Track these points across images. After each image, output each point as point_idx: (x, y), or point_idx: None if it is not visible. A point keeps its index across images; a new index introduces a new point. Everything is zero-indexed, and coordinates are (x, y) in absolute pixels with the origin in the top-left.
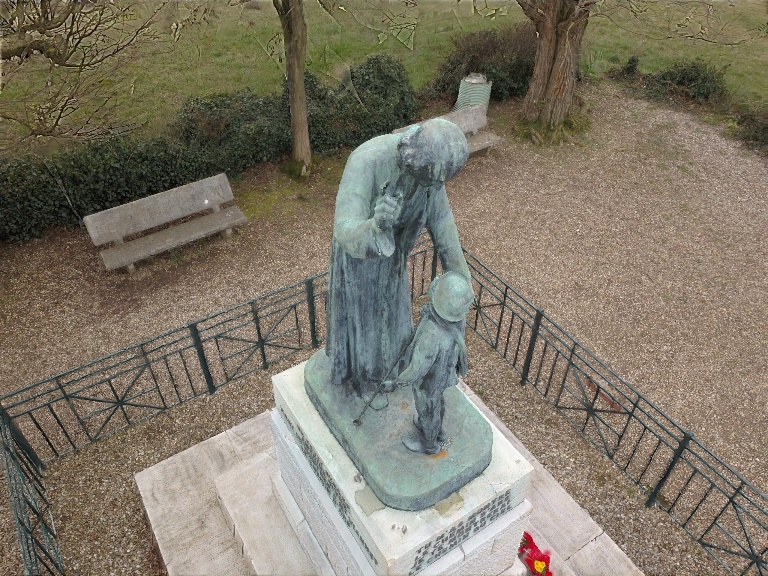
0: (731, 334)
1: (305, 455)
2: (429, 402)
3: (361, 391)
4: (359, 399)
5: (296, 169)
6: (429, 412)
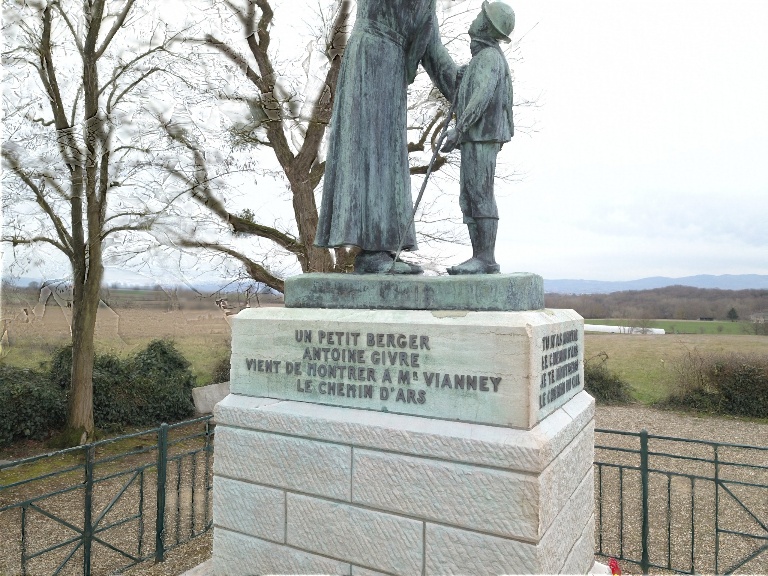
0: None
1: (307, 389)
2: (489, 166)
3: (376, 264)
4: (376, 273)
5: (73, 438)
6: (489, 186)
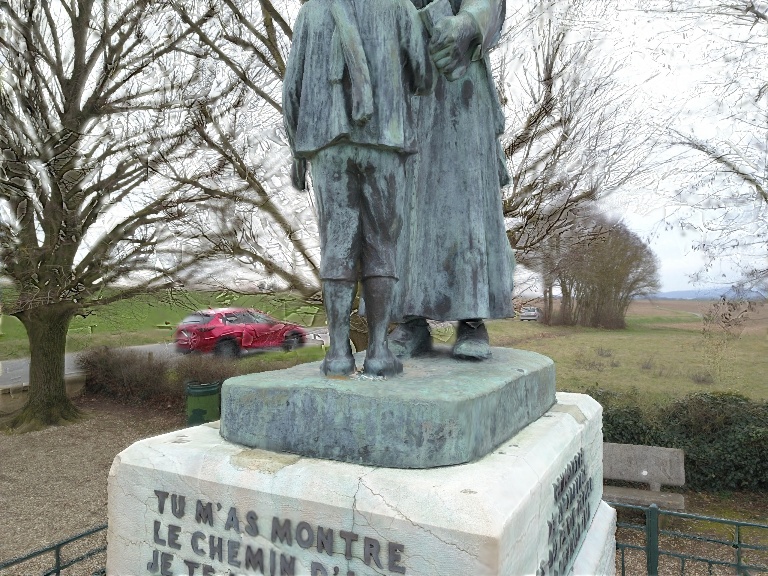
0: None
1: None
2: (319, 193)
3: None
4: None
5: None
6: (322, 227)
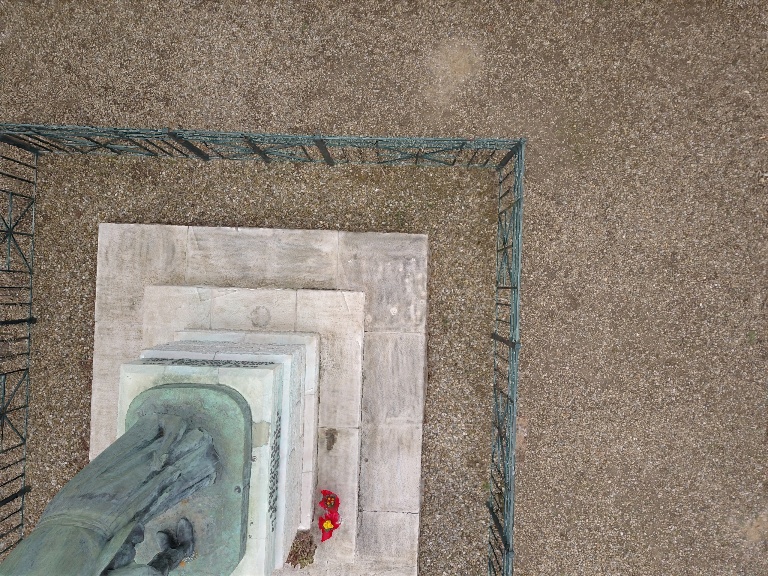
0: (760, 422)
1: None
2: None
3: None
4: None
5: None
6: None
